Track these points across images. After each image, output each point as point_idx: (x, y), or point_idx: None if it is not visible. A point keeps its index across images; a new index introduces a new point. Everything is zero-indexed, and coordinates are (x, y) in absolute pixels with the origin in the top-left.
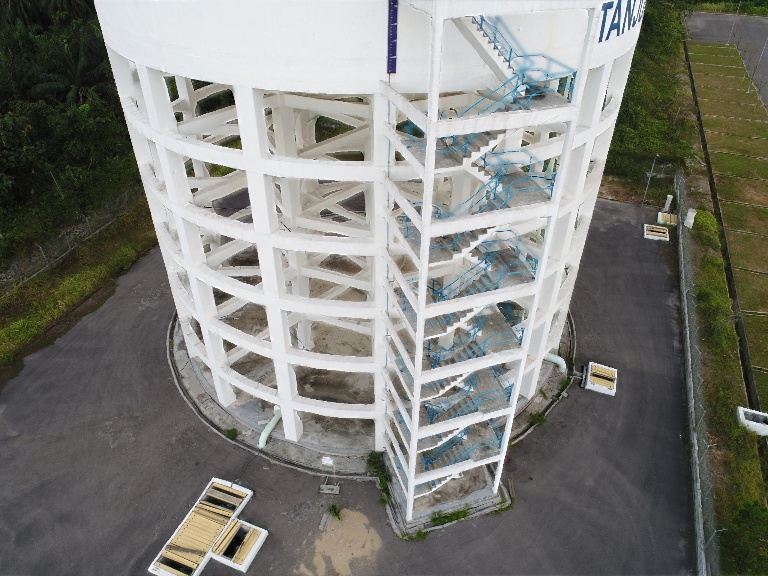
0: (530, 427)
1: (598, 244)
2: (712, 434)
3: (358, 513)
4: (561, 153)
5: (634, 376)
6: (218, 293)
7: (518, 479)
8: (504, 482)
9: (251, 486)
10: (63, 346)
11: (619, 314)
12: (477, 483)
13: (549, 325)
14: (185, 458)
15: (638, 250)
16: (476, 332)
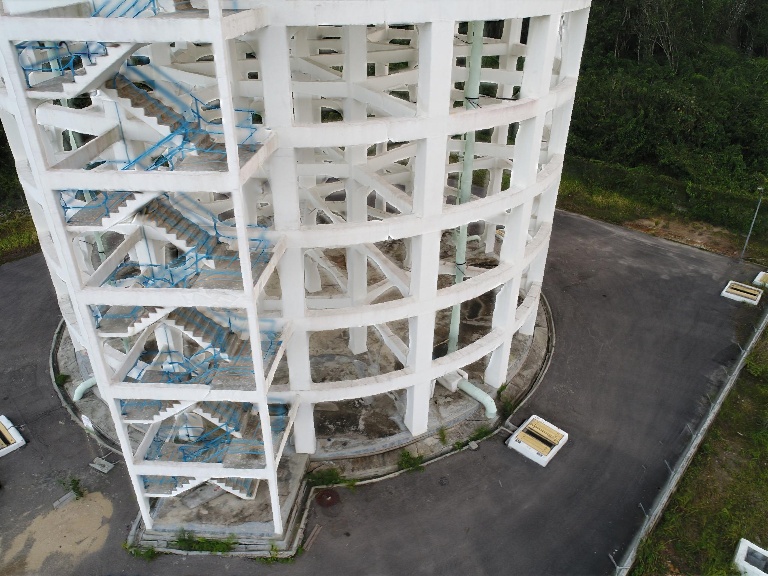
0: (397, 471)
1: (647, 290)
2: (676, 566)
3: (108, 502)
4: (370, 22)
5: (593, 450)
6: (169, 252)
7: (330, 529)
8: (308, 526)
9: (30, 435)
10: (5, 269)
11: (622, 372)
12: (264, 513)
13: (430, 325)
14: (1, 390)
15: (702, 307)
16: (199, 258)
